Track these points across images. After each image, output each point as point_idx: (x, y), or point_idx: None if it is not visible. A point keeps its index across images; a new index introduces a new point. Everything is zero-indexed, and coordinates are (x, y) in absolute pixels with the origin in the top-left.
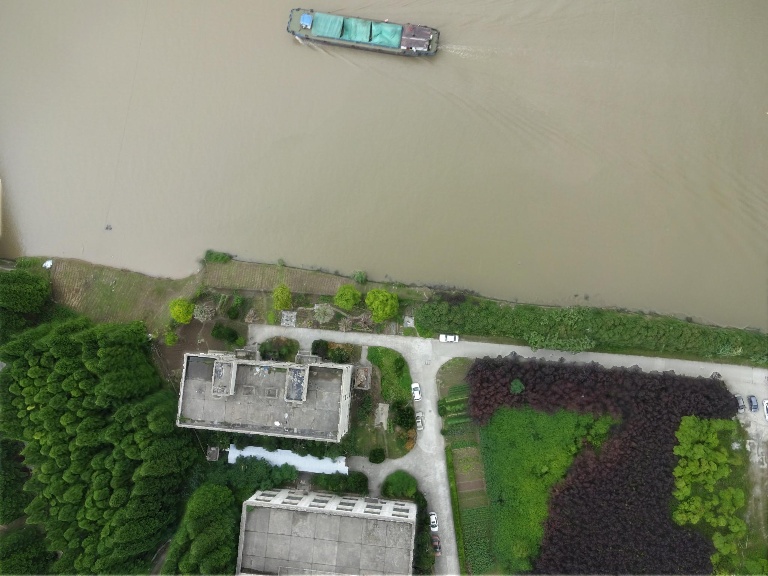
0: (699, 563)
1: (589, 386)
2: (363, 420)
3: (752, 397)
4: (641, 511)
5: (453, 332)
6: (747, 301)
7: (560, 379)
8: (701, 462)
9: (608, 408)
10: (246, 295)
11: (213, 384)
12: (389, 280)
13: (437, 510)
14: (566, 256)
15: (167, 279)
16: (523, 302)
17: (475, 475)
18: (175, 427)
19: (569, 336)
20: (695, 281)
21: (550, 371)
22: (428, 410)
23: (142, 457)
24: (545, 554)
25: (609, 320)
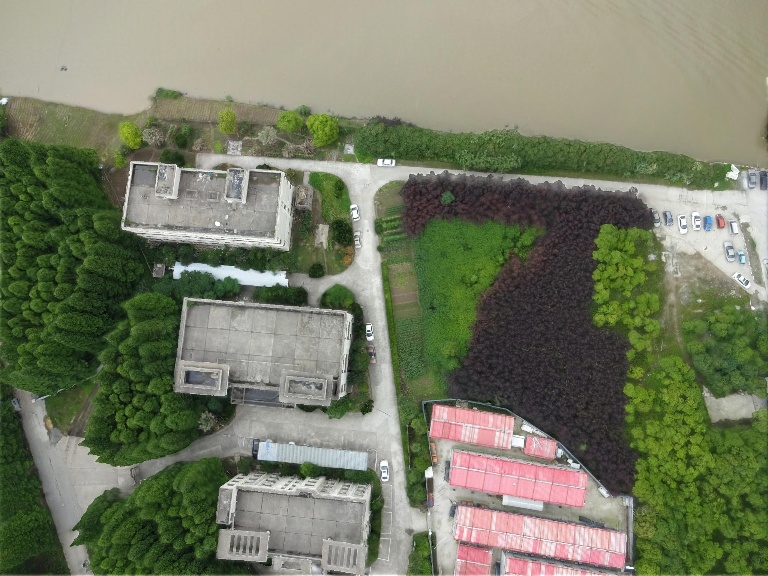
0: (616, 359)
1: (515, 198)
2: (303, 236)
3: (667, 211)
4: (563, 313)
5: (389, 154)
6: (664, 129)
7: (488, 192)
8: (618, 267)
9: (533, 219)
10: (194, 126)
11: (157, 185)
12: (331, 114)
13: (373, 322)
14: (497, 90)
15: (119, 114)
16: (457, 133)
17: (409, 288)
18: (121, 238)
19: (497, 154)
20: (616, 111)
21: (479, 184)
22: (366, 230)
23: (86, 249)
24: (472, 352)
25: (534, 138)
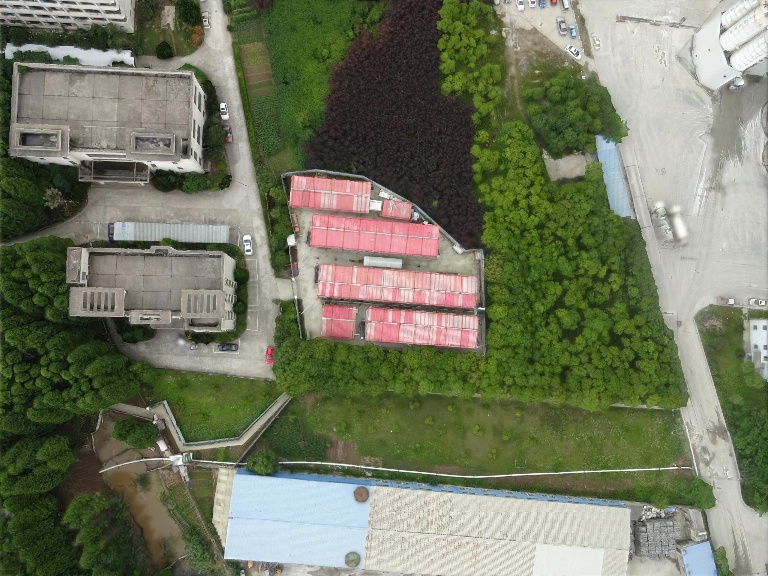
0: (463, 122)
1: None
2: (147, 13)
3: None
4: (412, 82)
5: None
6: None
7: None
8: (461, 37)
9: None
10: None
11: None
12: None
13: (227, 101)
14: None
15: None
16: None
17: (262, 67)
18: None
19: None
20: None
21: None
22: (214, 10)
23: None
24: (326, 120)
25: None
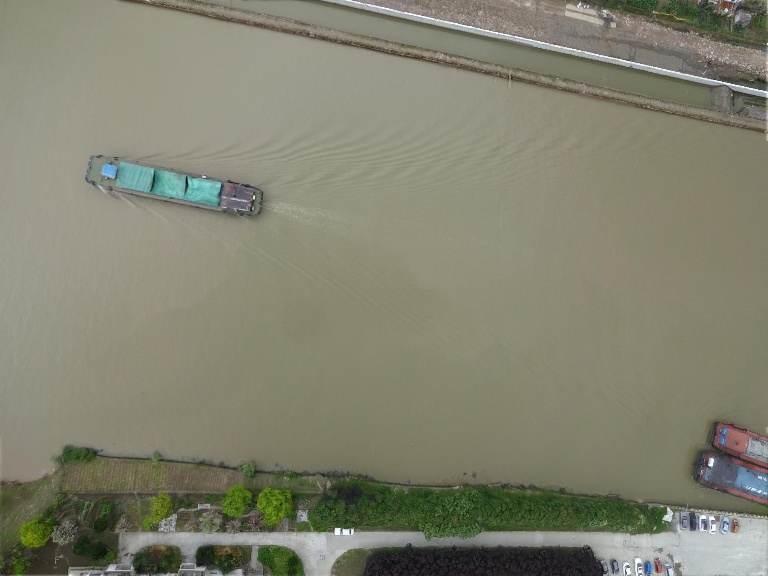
0: None
1: (480, 573)
2: None
3: (614, 562)
4: None
5: (349, 527)
6: (609, 469)
7: (453, 569)
8: None
9: None
10: (116, 499)
11: None
12: (280, 469)
13: None
14: (456, 435)
15: (13, 485)
16: (416, 483)
17: None
18: None
19: (461, 524)
20: (567, 454)
21: (444, 563)
22: None
23: None
24: None
25: (497, 506)
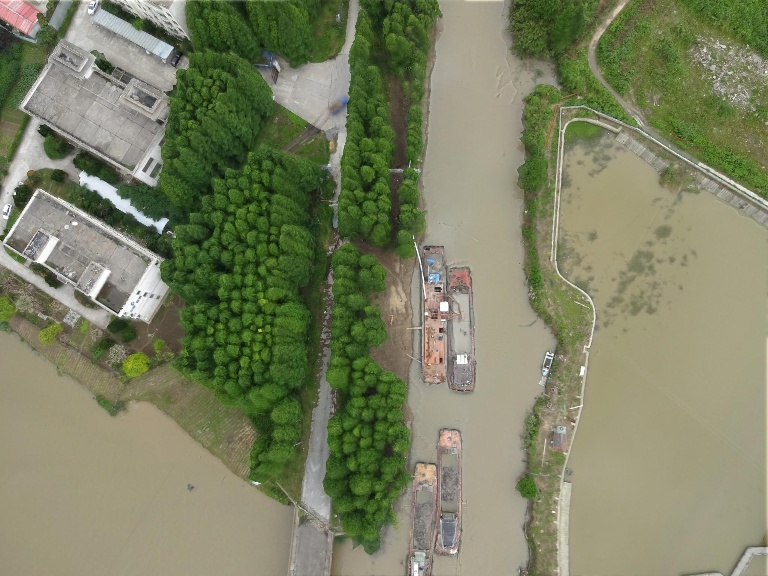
0: None
1: None
2: None
3: None
4: None
5: None
6: None
7: None
8: None
9: None
10: None
11: (99, 277)
12: None
13: None
14: None
15: None
16: None
17: (3, 133)
18: None
19: None
20: None
21: None
22: (9, 195)
23: (173, 240)
24: None
25: None
